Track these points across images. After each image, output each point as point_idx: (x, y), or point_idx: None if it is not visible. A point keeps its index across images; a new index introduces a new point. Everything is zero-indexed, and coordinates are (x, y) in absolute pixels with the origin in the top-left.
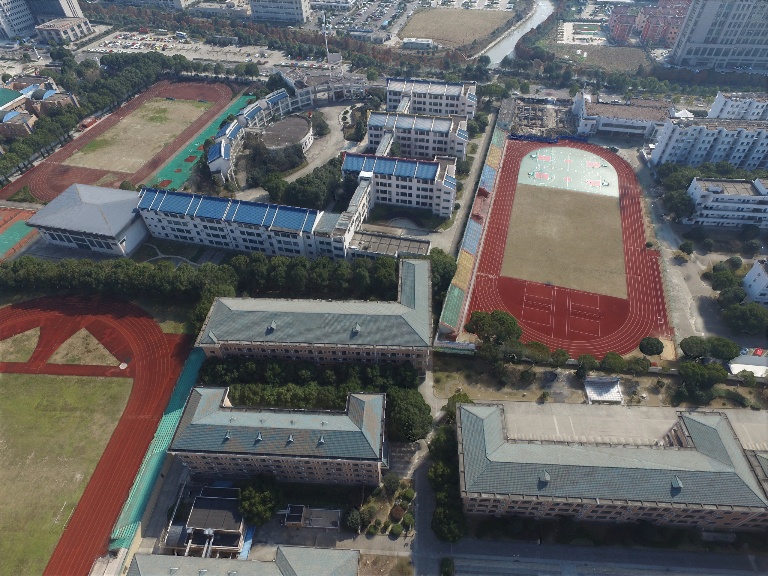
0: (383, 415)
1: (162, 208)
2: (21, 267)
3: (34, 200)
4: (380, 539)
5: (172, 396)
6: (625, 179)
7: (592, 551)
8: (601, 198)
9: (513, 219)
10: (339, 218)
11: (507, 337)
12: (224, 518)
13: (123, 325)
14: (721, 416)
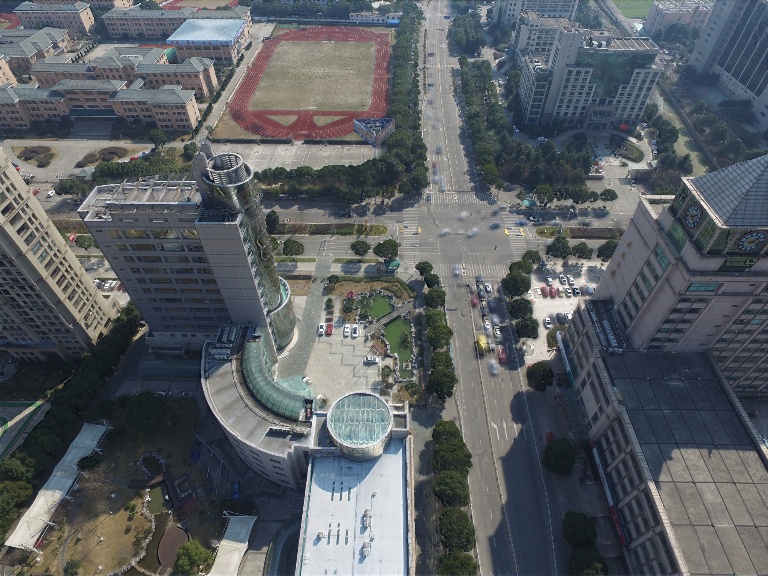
0: None
1: None
2: None
3: None
4: None
5: None
6: None
7: (146, 41)
8: None
9: None
10: None
11: None
12: None
13: None
14: (195, 8)
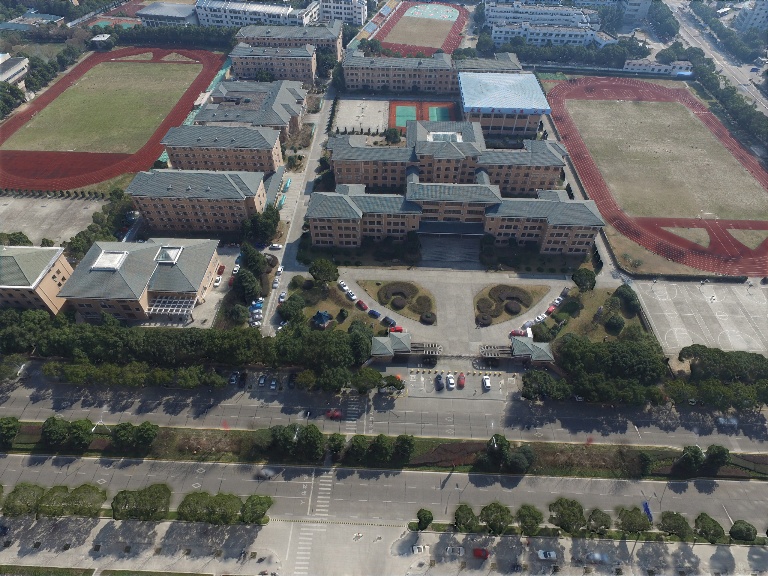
0: None
1: (209, 6)
2: (139, 28)
3: (128, 16)
4: (312, 94)
5: (223, 66)
6: (462, 15)
7: (393, 96)
8: (445, 21)
9: (396, 26)
10: (301, 10)
11: (375, 47)
12: (251, 81)
13: (194, 52)
14: (449, 54)
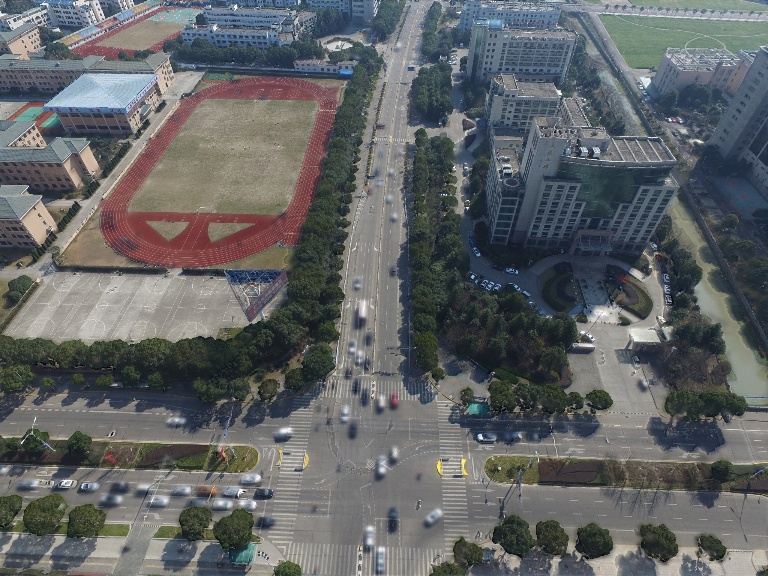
0: None
1: None
2: None
3: None
4: None
5: None
6: None
7: (39, 97)
8: (181, 24)
9: (125, 30)
10: (12, 15)
11: None
12: None
13: None
14: (102, 56)
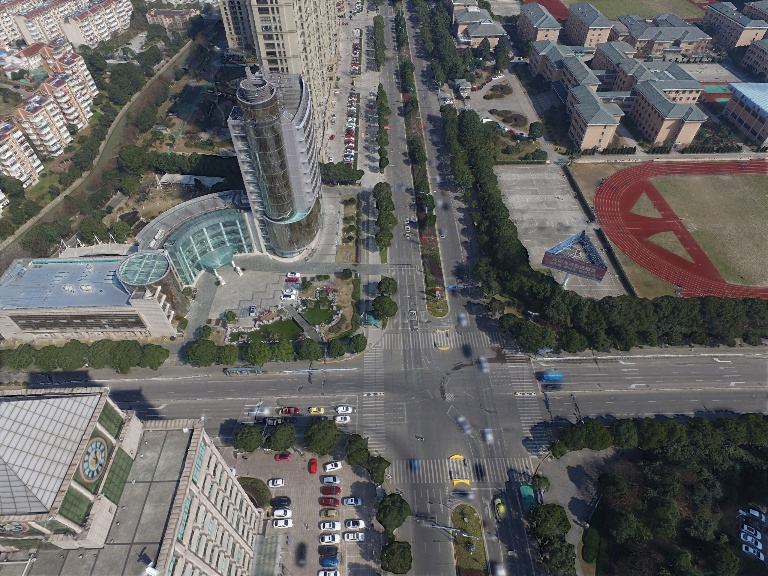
0: (762, 27)
1: None
2: None
3: None
4: None
5: None
6: None
7: None
8: None
9: None
10: None
11: None
12: None
13: None
14: None
